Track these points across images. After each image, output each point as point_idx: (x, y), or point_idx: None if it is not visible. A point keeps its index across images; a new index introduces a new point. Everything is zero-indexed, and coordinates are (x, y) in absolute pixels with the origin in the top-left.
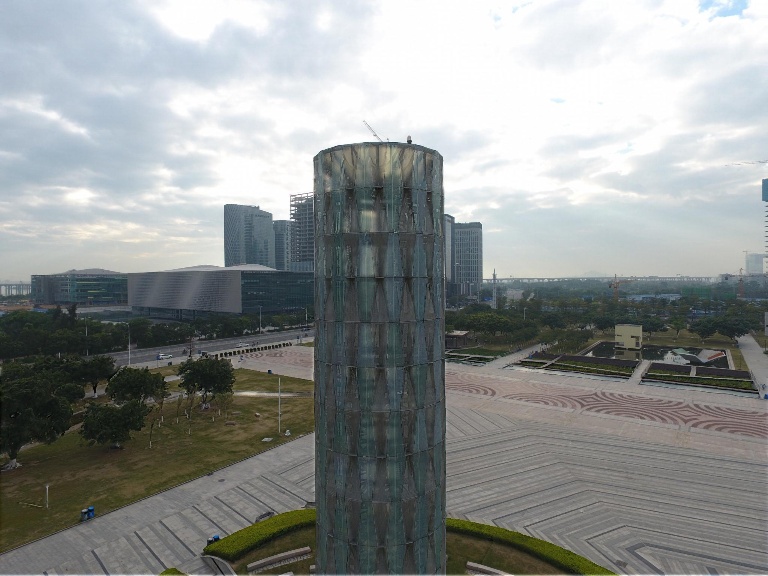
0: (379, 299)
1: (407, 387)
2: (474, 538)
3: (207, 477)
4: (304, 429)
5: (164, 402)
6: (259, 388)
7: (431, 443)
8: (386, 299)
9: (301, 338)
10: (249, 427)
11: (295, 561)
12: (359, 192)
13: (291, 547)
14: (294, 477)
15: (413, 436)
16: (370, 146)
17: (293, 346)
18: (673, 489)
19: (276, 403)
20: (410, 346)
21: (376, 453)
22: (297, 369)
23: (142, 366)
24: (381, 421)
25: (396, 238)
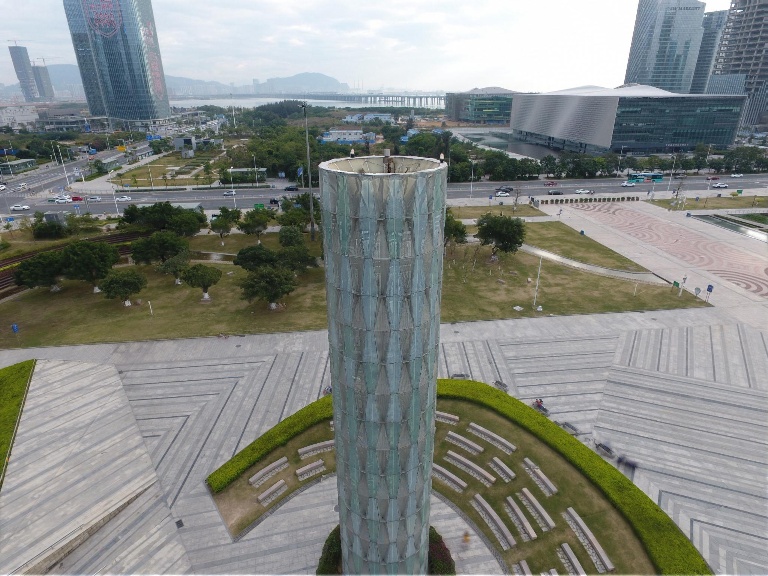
0: (340, 304)
1: (361, 375)
2: (600, 493)
3: (449, 325)
4: (559, 309)
5: (469, 244)
6: (556, 250)
7: (385, 419)
8: (342, 307)
9: (653, 194)
10: (513, 290)
11: (443, 422)
12: (326, 214)
13: (448, 410)
14: (510, 353)
15: (365, 409)
16: (330, 174)
17: (639, 202)
18: None
19: (558, 272)
20: (362, 347)
21: (342, 407)
22: (616, 235)
23: (479, 201)
24: (344, 389)
25: (347, 260)
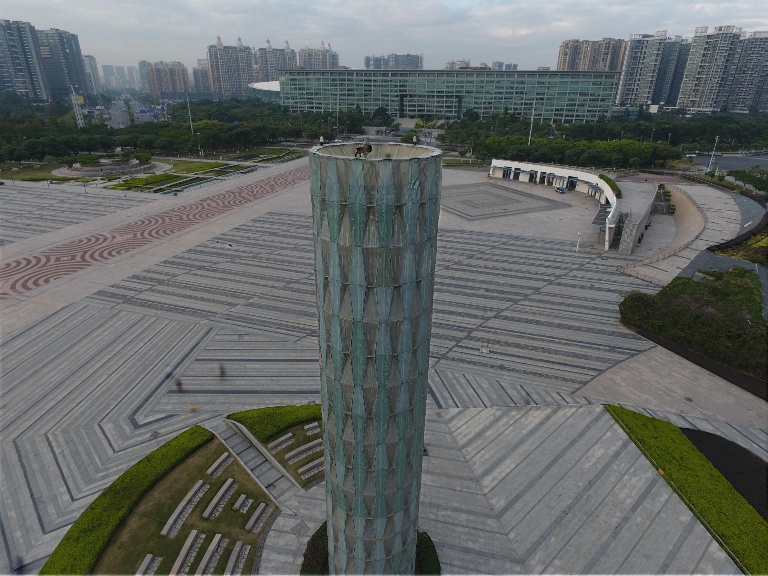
0: None
1: None
2: (121, 529)
3: None
4: None
5: None
6: None
7: None
8: None
9: None
10: None
11: None
12: None
13: None
14: None
15: None
16: None
17: None
18: (44, 384)
19: None
20: None
21: None
22: None
23: None
24: None
25: None
